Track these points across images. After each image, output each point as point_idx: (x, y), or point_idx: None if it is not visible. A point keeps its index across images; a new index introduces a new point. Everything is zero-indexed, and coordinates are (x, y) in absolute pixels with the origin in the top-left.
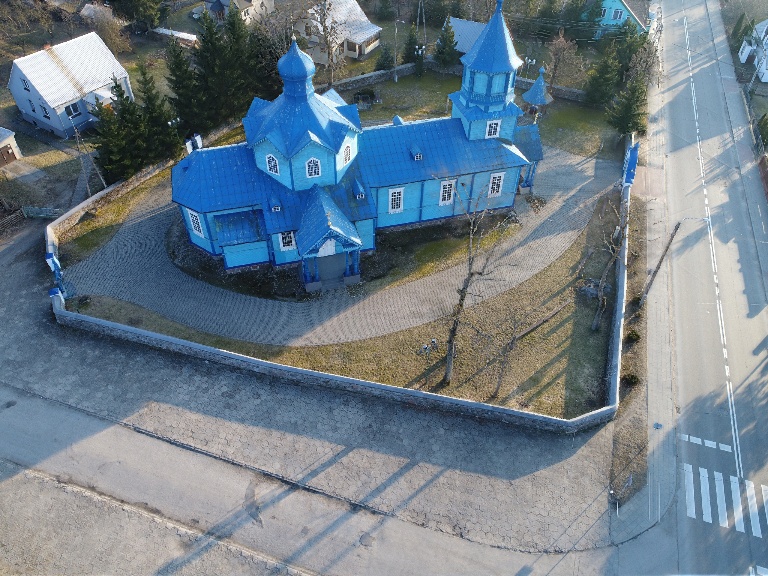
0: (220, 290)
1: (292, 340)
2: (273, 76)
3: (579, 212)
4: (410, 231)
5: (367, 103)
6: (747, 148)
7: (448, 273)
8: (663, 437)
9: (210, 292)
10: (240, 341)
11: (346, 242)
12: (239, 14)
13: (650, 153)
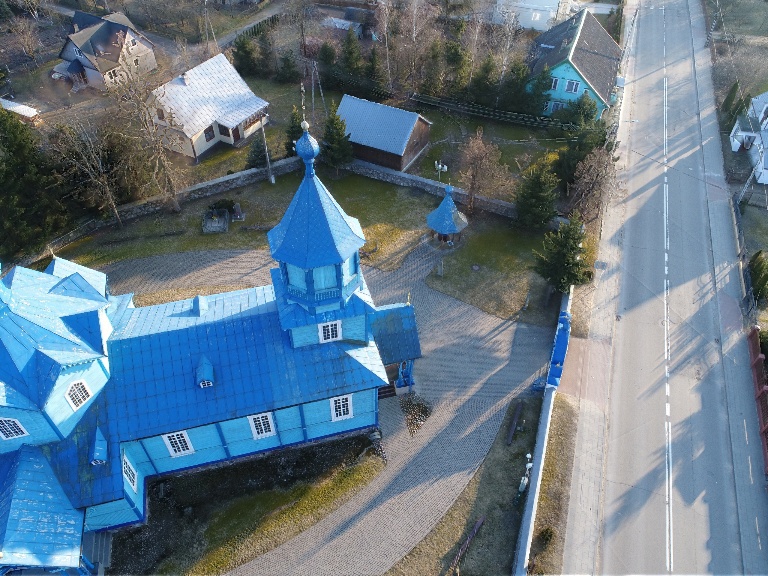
0: None
1: None
2: None
3: (476, 432)
4: (214, 473)
5: (224, 220)
6: (733, 303)
7: (248, 571)
8: None
9: None
10: None
11: None
12: (16, 118)
13: (595, 313)
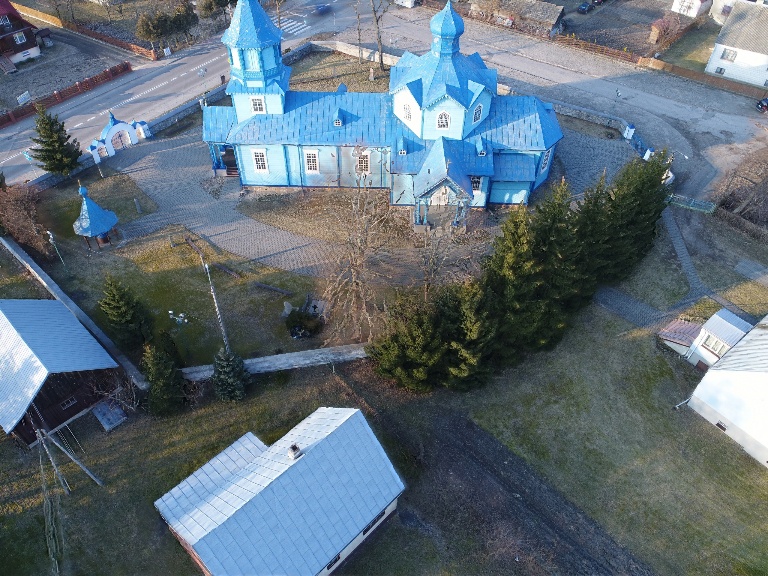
0: None
1: None
2: None
3: None
4: None
5: None
6: None
7: None
8: (296, 39)
9: None
10: None
11: None
12: None
13: None
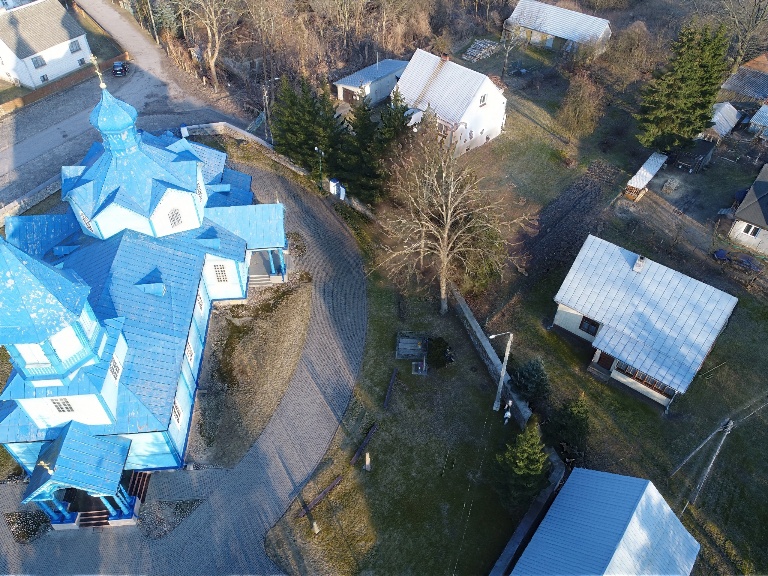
0: None
1: None
2: None
3: None
4: None
5: None
6: None
7: None
8: None
9: None
10: None
11: None
12: None
13: None
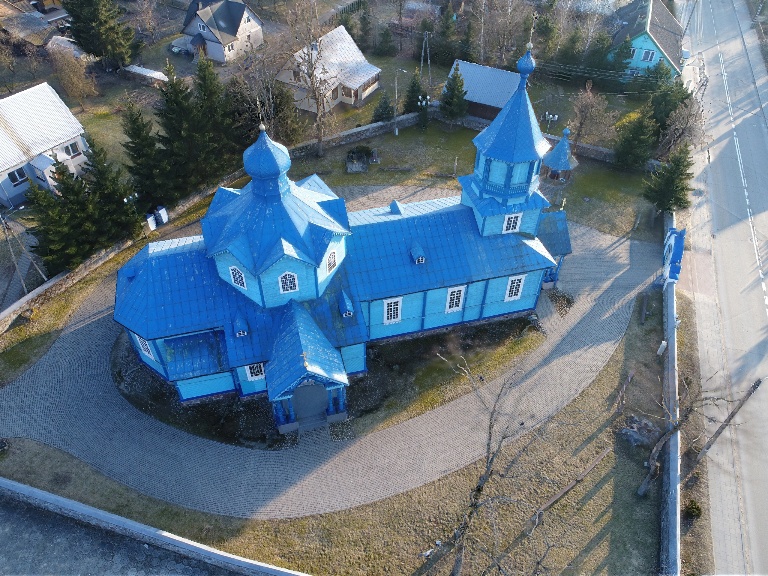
0: (172, 430)
1: (258, 509)
2: (252, 136)
3: (614, 315)
4: (410, 342)
5: (362, 163)
6: None
7: (456, 405)
8: None
9: (160, 433)
10: (192, 511)
11: (328, 380)
12: (211, 67)
13: (694, 232)
